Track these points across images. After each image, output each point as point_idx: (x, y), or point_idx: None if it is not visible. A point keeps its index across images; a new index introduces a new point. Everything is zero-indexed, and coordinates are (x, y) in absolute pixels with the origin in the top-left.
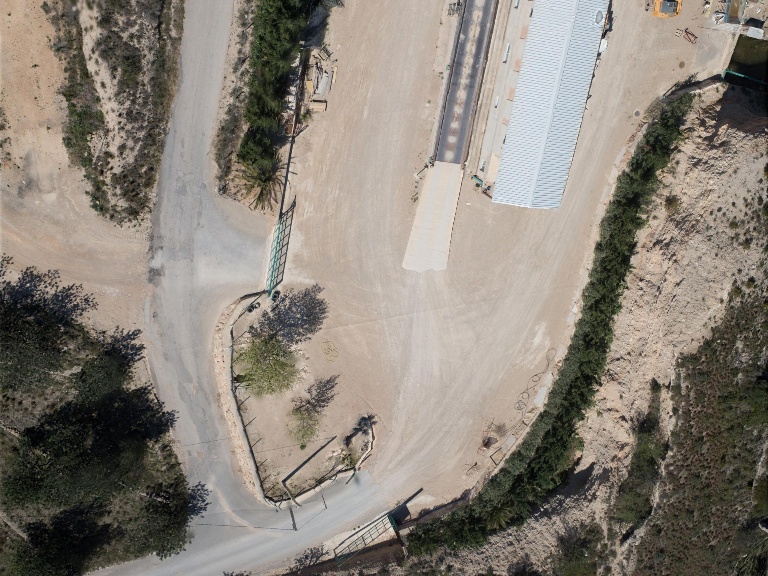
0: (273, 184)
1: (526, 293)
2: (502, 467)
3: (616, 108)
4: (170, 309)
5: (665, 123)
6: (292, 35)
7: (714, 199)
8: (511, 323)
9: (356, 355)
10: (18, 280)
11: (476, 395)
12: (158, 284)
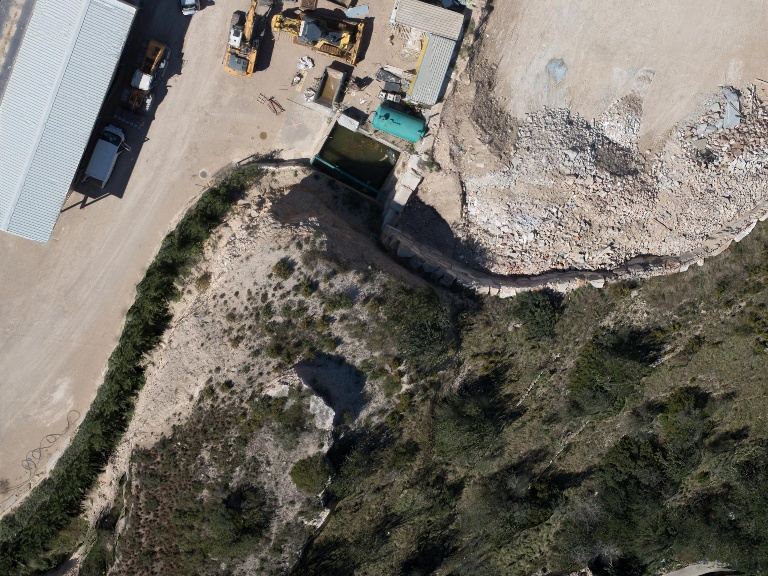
0: None
1: (48, 338)
2: None
3: (178, 161)
4: None
5: (218, 190)
6: None
7: (221, 283)
8: (27, 367)
9: None
10: None
11: None
12: None
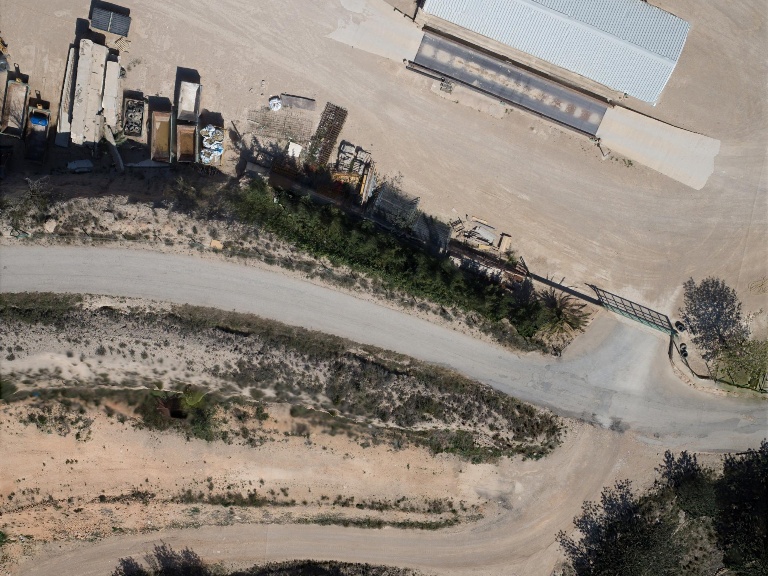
0: (566, 305)
1: None
2: None
3: None
4: (656, 421)
5: None
6: (429, 274)
7: None
8: None
9: None
10: (582, 532)
11: None
12: (627, 426)
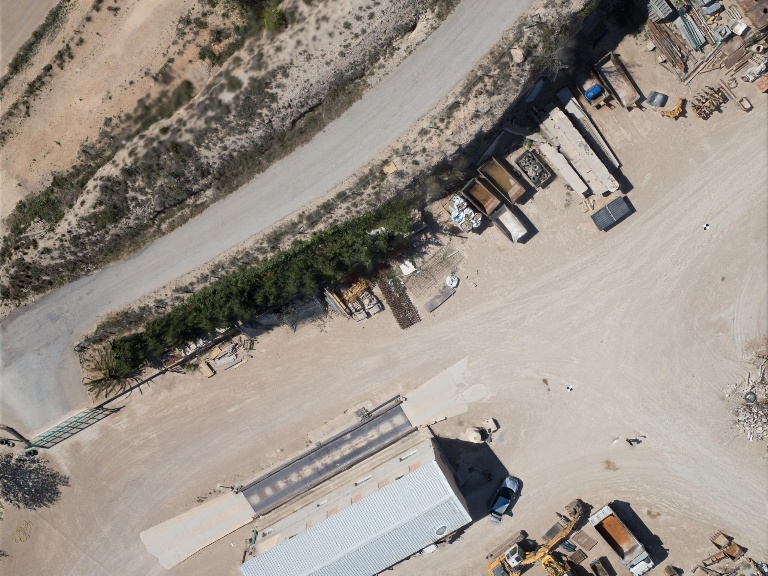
0: (117, 383)
1: None
2: None
3: None
4: None
5: None
6: (231, 315)
7: None
8: None
9: (37, 555)
10: None
11: None
12: None
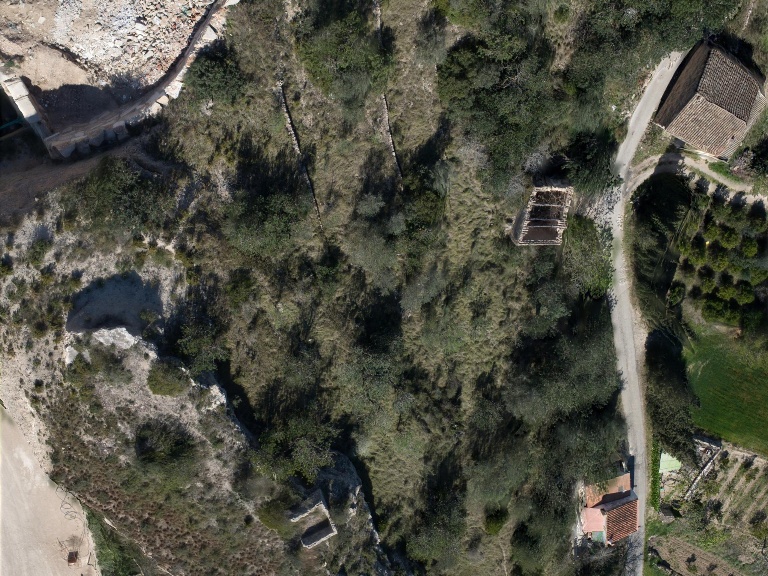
0: None
1: None
2: (101, 569)
3: None
4: None
5: None
6: None
7: None
8: None
9: None
10: None
11: (21, 532)
12: None
